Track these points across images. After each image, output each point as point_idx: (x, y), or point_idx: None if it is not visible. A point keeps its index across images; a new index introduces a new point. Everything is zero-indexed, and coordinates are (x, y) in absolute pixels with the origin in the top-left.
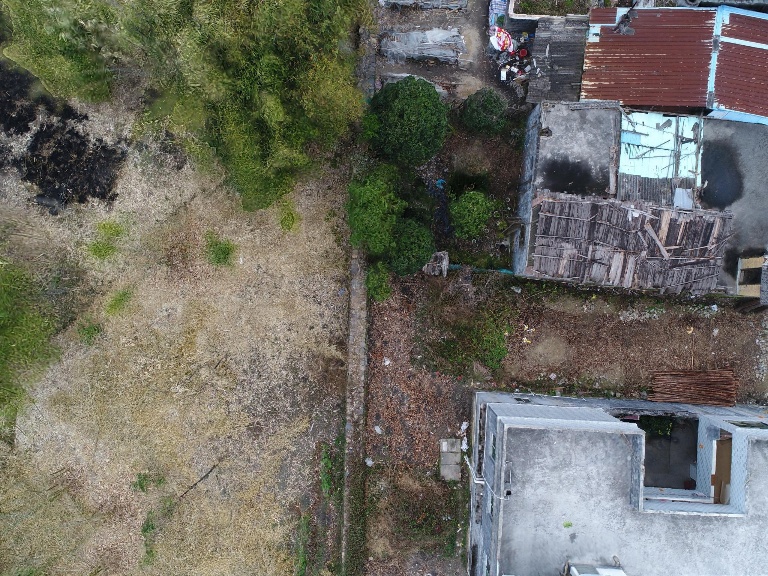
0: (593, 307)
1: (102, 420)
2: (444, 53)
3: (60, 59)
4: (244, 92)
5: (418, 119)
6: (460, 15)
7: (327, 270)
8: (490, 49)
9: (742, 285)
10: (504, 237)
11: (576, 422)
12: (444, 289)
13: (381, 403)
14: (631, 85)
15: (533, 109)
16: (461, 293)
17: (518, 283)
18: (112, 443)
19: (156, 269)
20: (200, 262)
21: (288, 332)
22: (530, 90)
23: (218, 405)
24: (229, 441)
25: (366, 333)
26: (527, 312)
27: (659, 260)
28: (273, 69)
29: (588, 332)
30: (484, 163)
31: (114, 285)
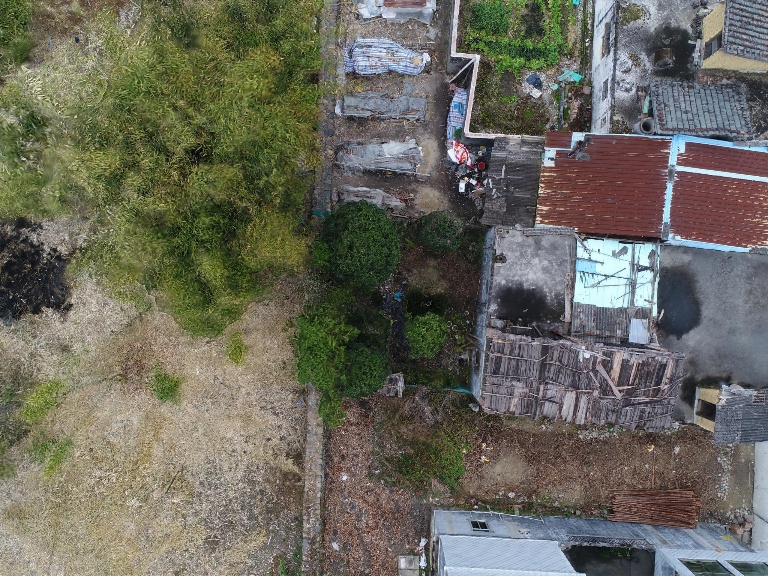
0: (552, 426)
1: (57, 533)
2: (401, 166)
3: (5, 187)
4: (182, 247)
5: (368, 252)
6: (418, 125)
7: (285, 381)
8: (448, 161)
9: (699, 416)
10: (463, 351)
11: (524, 573)
12: (400, 409)
13: (338, 519)
14: (586, 212)
15: (489, 229)
16: (418, 412)
17: (476, 400)
18: (67, 556)
19: (111, 380)
20: (156, 373)
21: (245, 444)
22: (486, 211)
23: (174, 518)
24: (185, 554)
25: (323, 448)
26: (485, 430)
27: (612, 399)
28: (211, 224)
29: (547, 450)
30: (439, 285)
31: (69, 397)
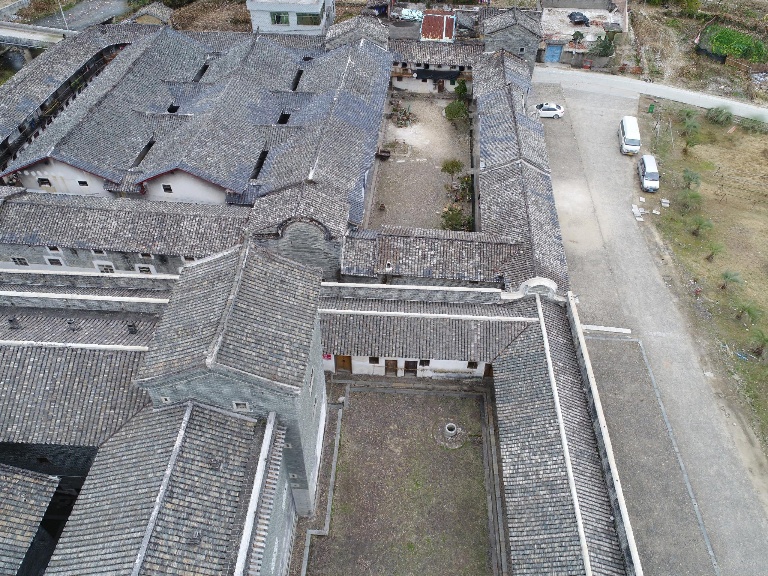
0: None
1: None
2: None
3: None
4: None
5: None
6: None
7: None
8: None
9: None
10: None
11: None
12: None
13: None
14: None
15: None
16: None
17: None
18: None
19: None
20: None
21: (358, 1)
22: None
23: None
24: None
25: (356, 5)
26: None
27: None
28: None
29: None
30: None
31: None
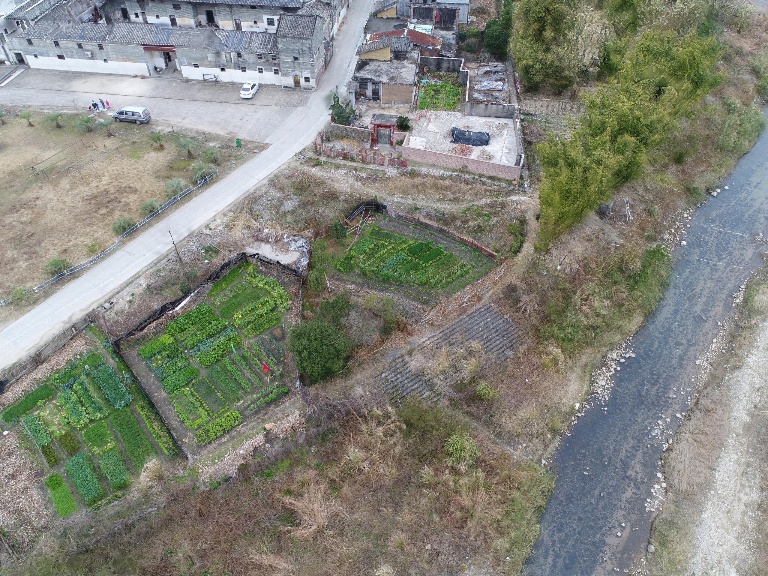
0: None
1: None
2: None
3: None
4: None
5: None
6: None
7: None
8: None
9: None
10: None
11: None
12: None
13: None
14: None
15: None
16: None
17: None
18: None
19: None
20: None
21: None
22: None
23: None
24: None
25: None
26: None
27: None
28: None
29: None
30: None
31: None
